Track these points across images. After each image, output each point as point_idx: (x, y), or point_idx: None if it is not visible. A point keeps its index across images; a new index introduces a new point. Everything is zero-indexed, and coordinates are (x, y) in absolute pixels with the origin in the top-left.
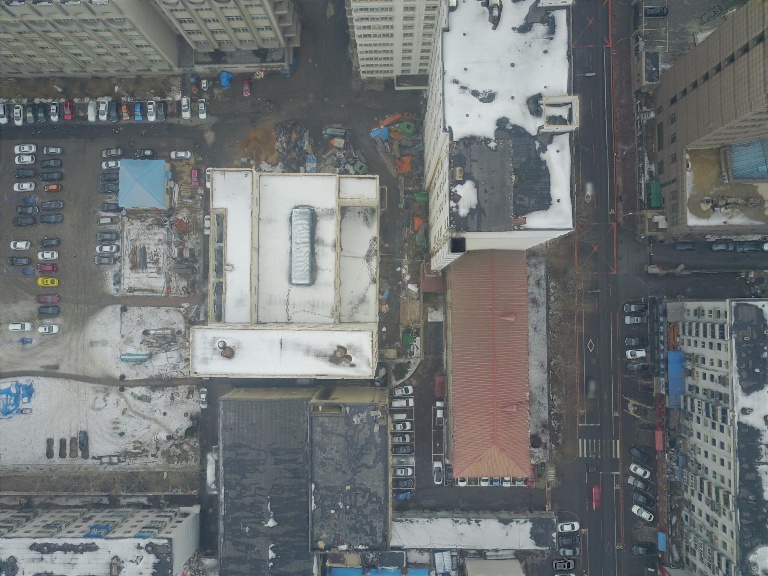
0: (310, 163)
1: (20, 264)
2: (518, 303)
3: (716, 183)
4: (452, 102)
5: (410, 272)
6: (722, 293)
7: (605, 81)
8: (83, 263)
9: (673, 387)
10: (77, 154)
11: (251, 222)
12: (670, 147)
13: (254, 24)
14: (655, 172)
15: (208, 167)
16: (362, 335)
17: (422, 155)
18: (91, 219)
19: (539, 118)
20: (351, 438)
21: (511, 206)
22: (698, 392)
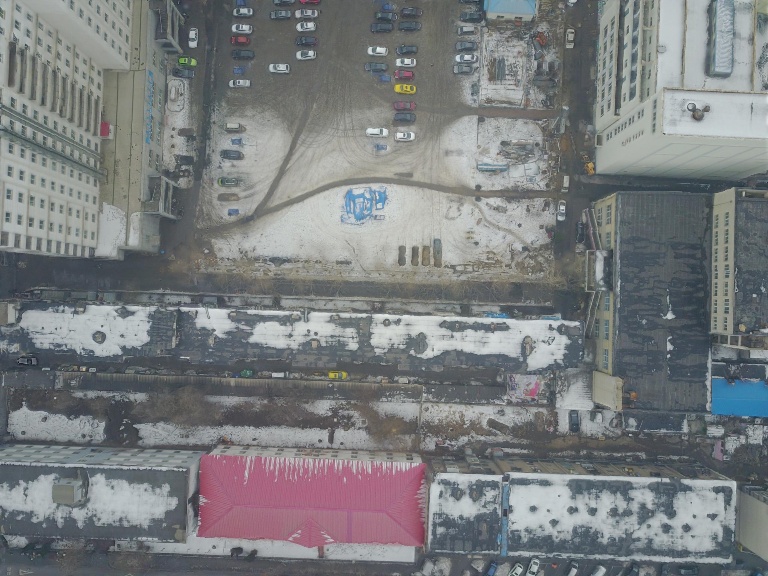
0: None
1: (378, 69)
2: None
3: None
4: None
5: None
6: None
7: None
8: (440, 72)
9: None
10: None
11: (684, 5)
12: None
13: None
14: None
15: None
16: None
17: None
18: (449, 29)
19: None
20: None
21: None
22: None
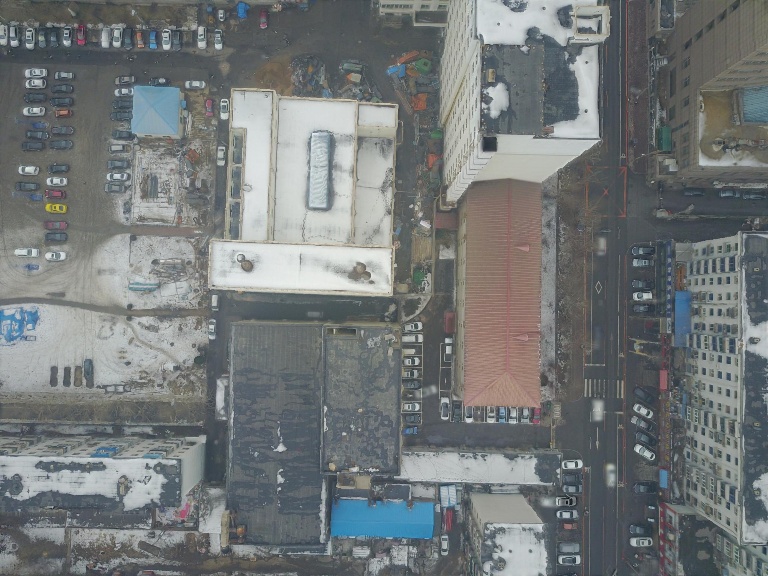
0: (326, 98)
1: (28, 189)
2: (533, 234)
3: (728, 125)
4: (484, 10)
5: (423, 209)
6: None
7: (620, 27)
8: (93, 191)
9: (679, 326)
10: (89, 81)
11: (270, 143)
12: (683, 90)
13: None
14: (666, 118)
15: (223, 98)
16: (382, 252)
17: (438, 93)
18: (102, 147)
19: (569, 29)
20: (365, 361)
21: (542, 110)
22: (704, 329)
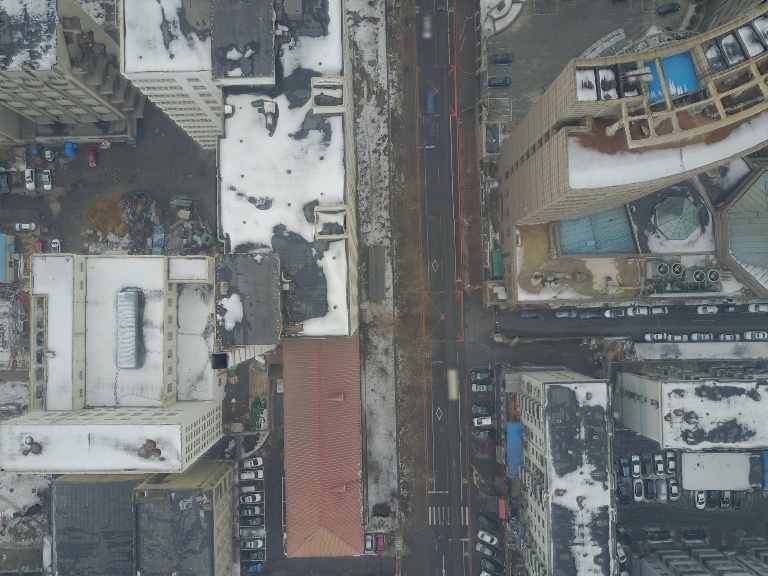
0: (157, 234)
1: None
2: (348, 382)
3: (546, 258)
4: (229, 209)
5: None
6: (566, 359)
7: (451, 150)
8: None
9: (512, 457)
10: None
11: (72, 308)
12: (506, 220)
13: (83, 103)
14: (499, 241)
15: (54, 239)
16: (171, 428)
17: None
18: None
19: None
20: (177, 524)
21: (277, 319)
22: (530, 465)
